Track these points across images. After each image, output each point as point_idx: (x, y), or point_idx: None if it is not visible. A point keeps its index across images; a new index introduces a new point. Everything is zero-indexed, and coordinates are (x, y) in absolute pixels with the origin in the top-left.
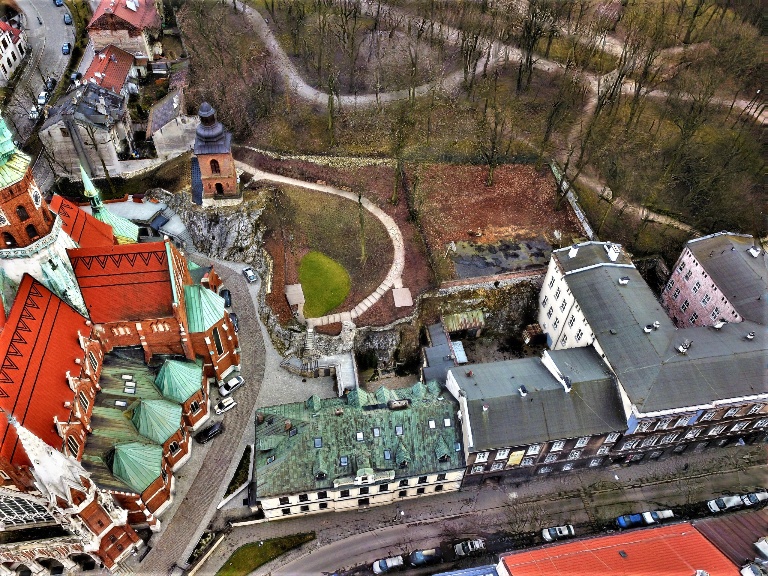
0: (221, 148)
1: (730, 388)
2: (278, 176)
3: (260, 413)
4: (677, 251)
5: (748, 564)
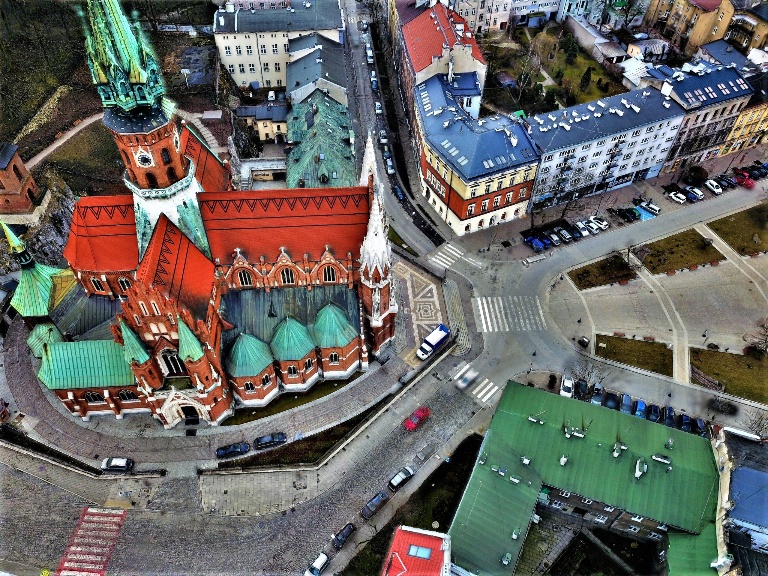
0: (10, 148)
1: (333, 2)
2: (32, 160)
3: (300, 177)
4: (209, 16)
5: (429, 3)
